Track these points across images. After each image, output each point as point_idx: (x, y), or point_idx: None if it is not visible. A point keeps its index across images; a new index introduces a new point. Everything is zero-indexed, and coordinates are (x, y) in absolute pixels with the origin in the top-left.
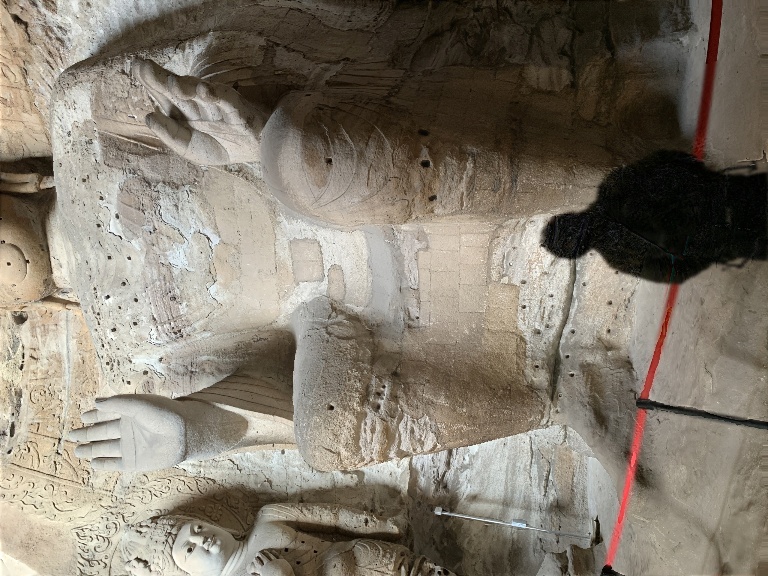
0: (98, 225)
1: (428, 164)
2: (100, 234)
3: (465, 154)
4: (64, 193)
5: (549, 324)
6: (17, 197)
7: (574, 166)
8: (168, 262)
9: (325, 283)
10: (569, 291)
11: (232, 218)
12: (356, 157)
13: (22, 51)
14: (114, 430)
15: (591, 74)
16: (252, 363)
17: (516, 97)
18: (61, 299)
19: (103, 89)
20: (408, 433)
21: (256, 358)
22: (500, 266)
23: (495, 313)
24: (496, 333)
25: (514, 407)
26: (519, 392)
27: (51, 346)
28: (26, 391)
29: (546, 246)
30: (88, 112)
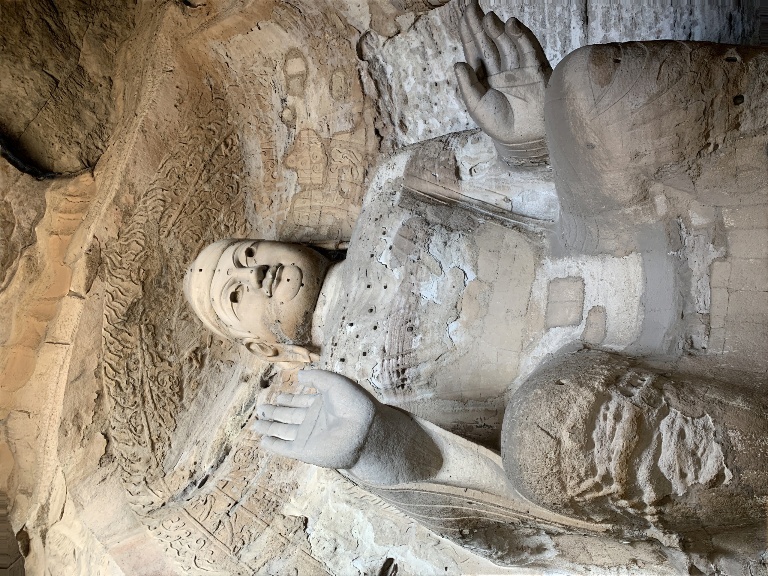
0: (372, 255)
1: (734, 60)
2: (370, 264)
3: None
4: (356, 234)
5: None
6: None
7: None
8: (419, 293)
9: (581, 327)
10: None
11: (495, 259)
12: (648, 55)
13: (371, 156)
14: (301, 412)
15: None
16: None
17: None
18: None
19: (420, 152)
20: (674, 435)
21: None
22: None
23: None
24: None
25: None
26: None
27: None
28: (235, 448)
29: None
30: (402, 171)
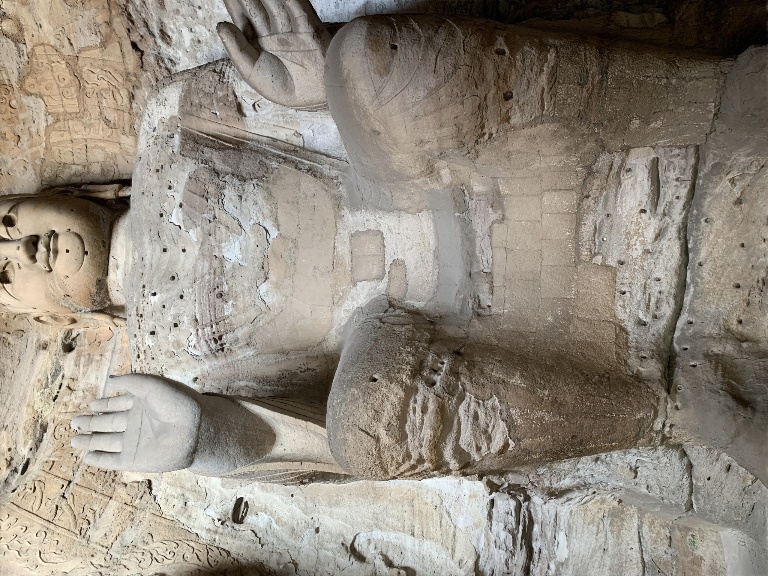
0: (161, 215)
1: (503, 53)
2: (161, 224)
3: (546, 46)
4: (137, 187)
5: (657, 314)
6: (95, 202)
7: (677, 60)
8: (222, 255)
9: (385, 281)
10: (681, 275)
11: (294, 211)
12: (423, 42)
13: (134, 76)
14: (121, 419)
15: (688, 10)
16: (294, 392)
17: (604, 30)
18: (111, 314)
19: (193, 86)
20: (470, 419)
21: (300, 388)
22: (591, 241)
23: (586, 299)
24: (588, 321)
25: (615, 396)
26: (621, 380)
27: (90, 378)
28: (52, 424)
29: (647, 211)
30: (176, 108)
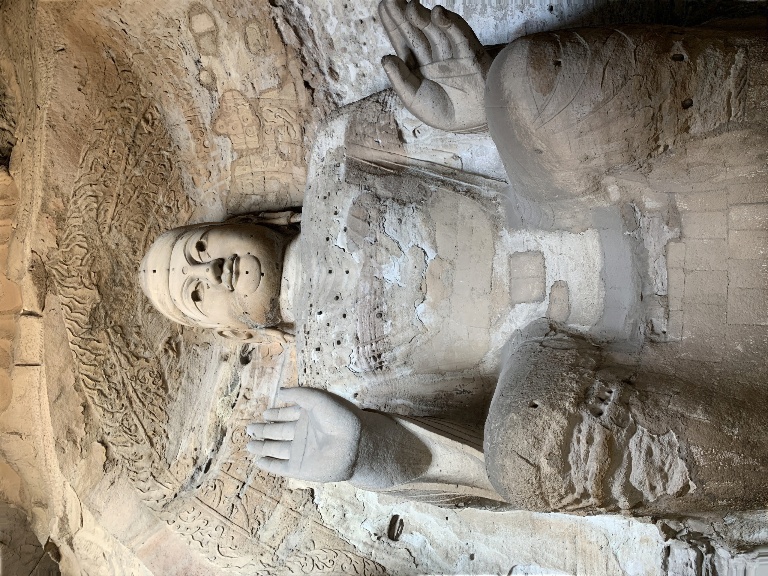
0: (327, 239)
1: (681, 58)
2: (327, 247)
3: (733, 47)
4: (307, 213)
5: None
6: (271, 228)
7: None
8: (382, 276)
9: (546, 303)
10: None
11: (452, 233)
12: (590, 56)
13: (305, 112)
14: (290, 428)
15: None
16: (450, 413)
17: None
18: None
19: (358, 117)
20: (643, 454)
21: (456, 410)
22: None
23: None
24: None
25: None
26: None
27: (263, 389)
28: (230, 429)
29: None
30: (342, 139)
